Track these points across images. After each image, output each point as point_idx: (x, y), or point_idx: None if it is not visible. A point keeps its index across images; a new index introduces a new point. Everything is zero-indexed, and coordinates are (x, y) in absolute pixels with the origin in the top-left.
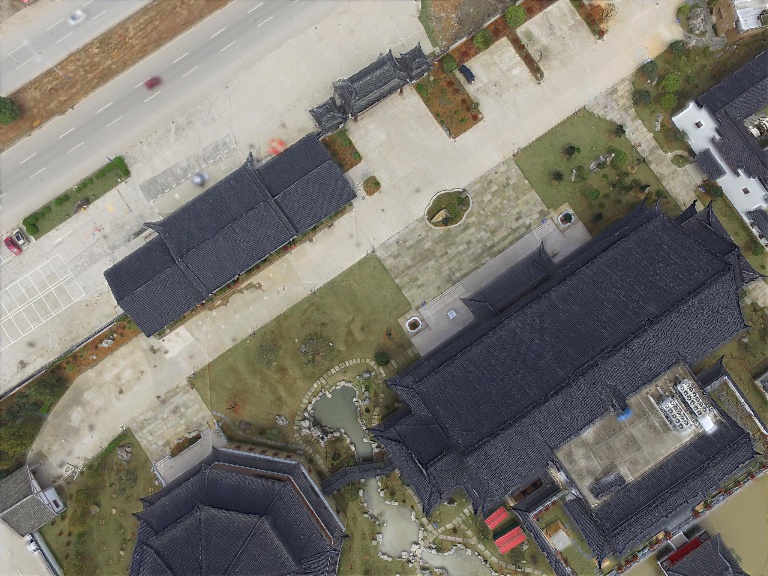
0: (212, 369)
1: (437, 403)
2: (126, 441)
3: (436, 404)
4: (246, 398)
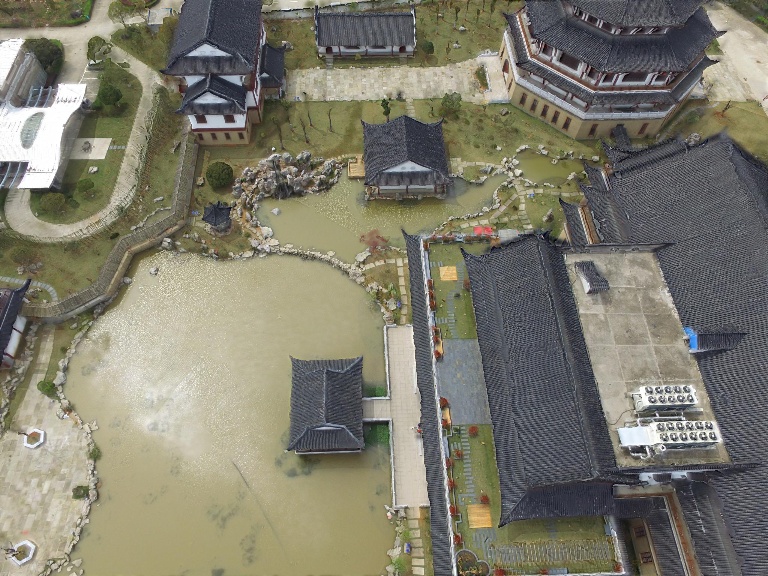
0: (763, 118)
1: (759, 175)
2: (713, 49)
3: (759, 173)
4: (726, 126)
